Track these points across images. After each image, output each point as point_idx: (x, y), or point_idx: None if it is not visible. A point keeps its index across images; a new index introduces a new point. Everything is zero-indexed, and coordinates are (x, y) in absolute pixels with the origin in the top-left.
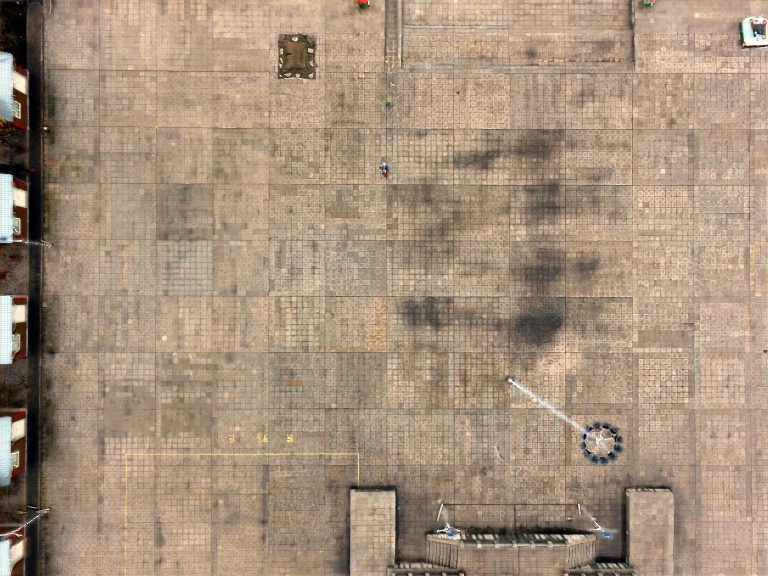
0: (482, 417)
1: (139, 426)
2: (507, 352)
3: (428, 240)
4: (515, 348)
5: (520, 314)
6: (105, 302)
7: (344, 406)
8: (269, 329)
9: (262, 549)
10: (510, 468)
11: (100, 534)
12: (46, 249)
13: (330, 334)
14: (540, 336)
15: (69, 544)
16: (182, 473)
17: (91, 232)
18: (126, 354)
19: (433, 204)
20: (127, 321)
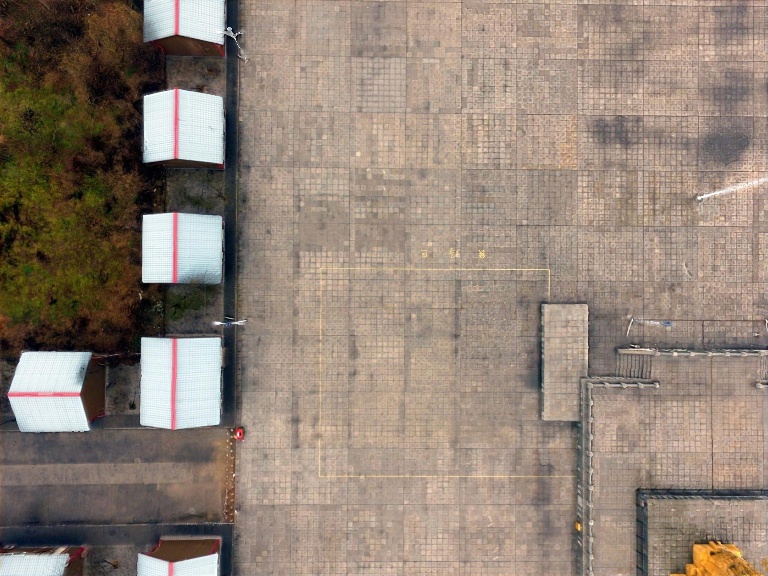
0: (671, 234)
1: (333, 240)
2: (695, 171)
3: (618, 59)
4: (703, 167)
5: (708, 133)
6: (300, 117)
7: (535, 223)
8: (461, 146)
9: (454, 362)
10: (698, 285)
11: (295, 346)
12: (242, 64)
13: (521, 151)
14: (728, 155)
15: (265, 355)
16: (376, 287)
17: (287, 48)
18: (321, 169)
19: (623, 24)
20: (322, 137)
